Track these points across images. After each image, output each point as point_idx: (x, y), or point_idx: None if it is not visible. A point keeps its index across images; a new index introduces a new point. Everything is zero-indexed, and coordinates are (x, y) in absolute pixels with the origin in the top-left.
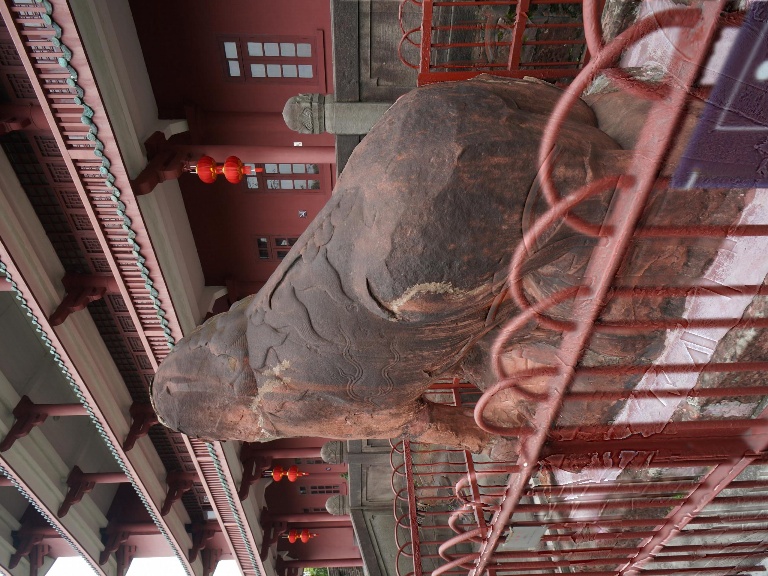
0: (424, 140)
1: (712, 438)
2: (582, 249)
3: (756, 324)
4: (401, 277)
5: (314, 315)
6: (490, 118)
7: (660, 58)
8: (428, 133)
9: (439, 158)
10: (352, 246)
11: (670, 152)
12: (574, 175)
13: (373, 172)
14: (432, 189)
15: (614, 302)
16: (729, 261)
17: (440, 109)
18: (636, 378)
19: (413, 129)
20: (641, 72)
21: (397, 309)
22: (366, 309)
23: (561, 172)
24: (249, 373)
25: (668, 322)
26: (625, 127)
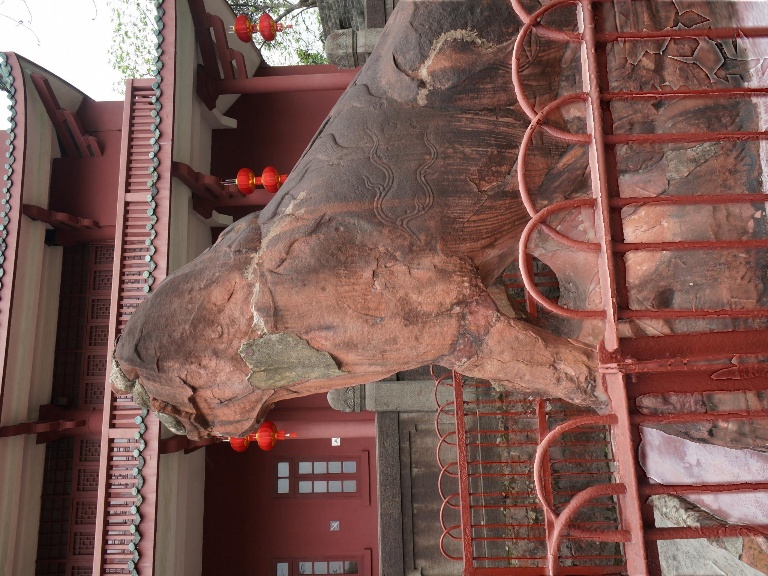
0: None
1: None
2: None
3: None
4: (426, 30)
5: (339, 132)
6: None
7: None
8: None
9: None
10: (379, 58)
11: None
12: None
13: None
14: None
15: (663, 69)
16: None
17: None
18: (754, 170)
19: None
20: None
21: (426, 73)
22: (395, 101)
23: None
24: (255, 228)
25: None
26: None
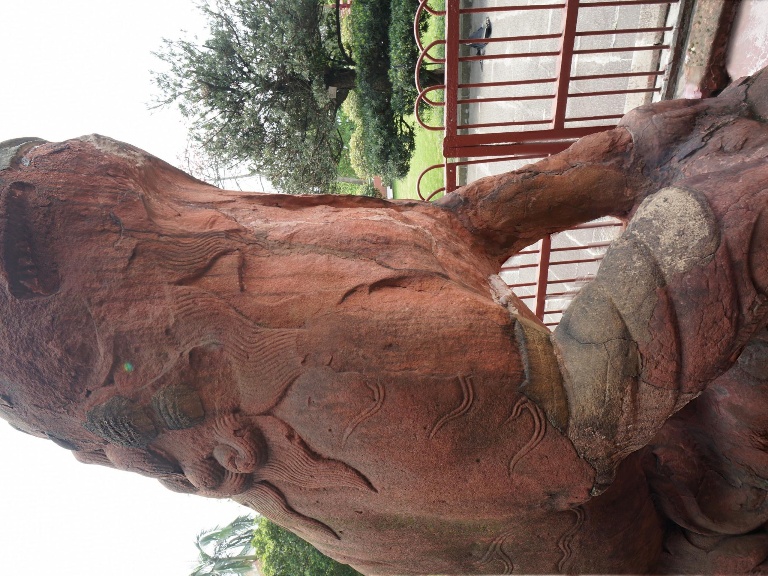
0: None
1: None
2: None
3: None
4: None
5: None
6: None
7: None
8: None
9: None
10: None
11: None
12: None
13: None
14: None
15: None
16: None
17: None
18: None
19: None
20: None
21: None
22: None
23: None
24: None
25: None
26: None
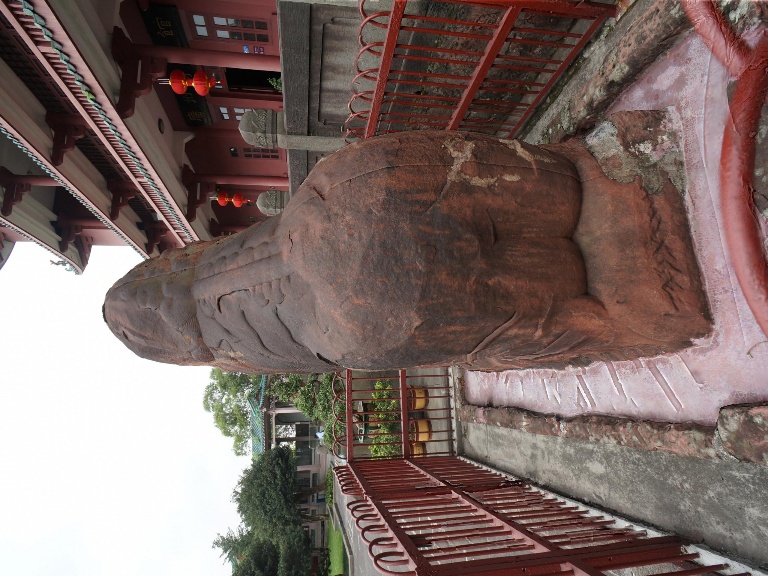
0: (384, 293)
1: (542, 557)
2: (516, 355)
3: (619, 441)
4: None
5: (265, 341)
6: (458, 279)
7: (686, 121)
8: (389, 285)
9: (397, 321)
10: (303, 322)
11: (621, 320)
12: (525, 332)
13: (327, 294)
14: (386, 343)
15: None
16: (631, 373)
17: (407, 252)
18: (537, 367)
19: (374, 271)
20: (658, 133)
21: None
22: None
23: (513, 332)
24: (205, 349)
25: (573, 363)
26: (599, 252)
